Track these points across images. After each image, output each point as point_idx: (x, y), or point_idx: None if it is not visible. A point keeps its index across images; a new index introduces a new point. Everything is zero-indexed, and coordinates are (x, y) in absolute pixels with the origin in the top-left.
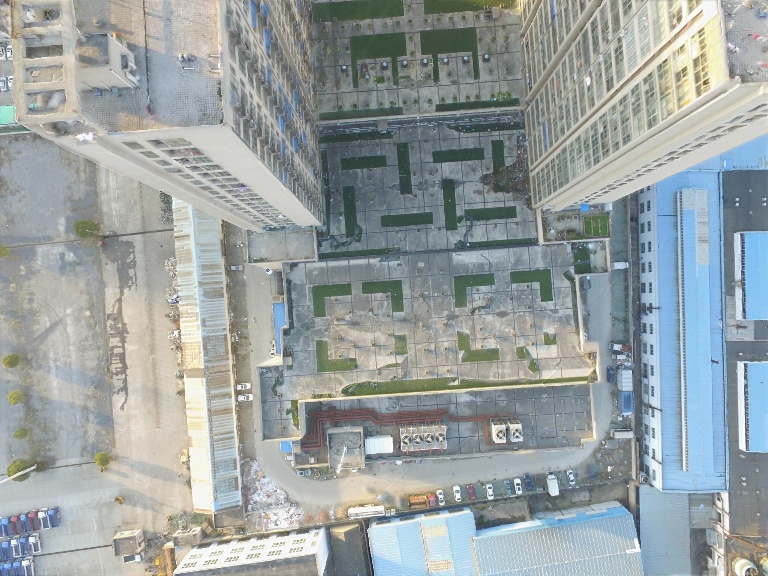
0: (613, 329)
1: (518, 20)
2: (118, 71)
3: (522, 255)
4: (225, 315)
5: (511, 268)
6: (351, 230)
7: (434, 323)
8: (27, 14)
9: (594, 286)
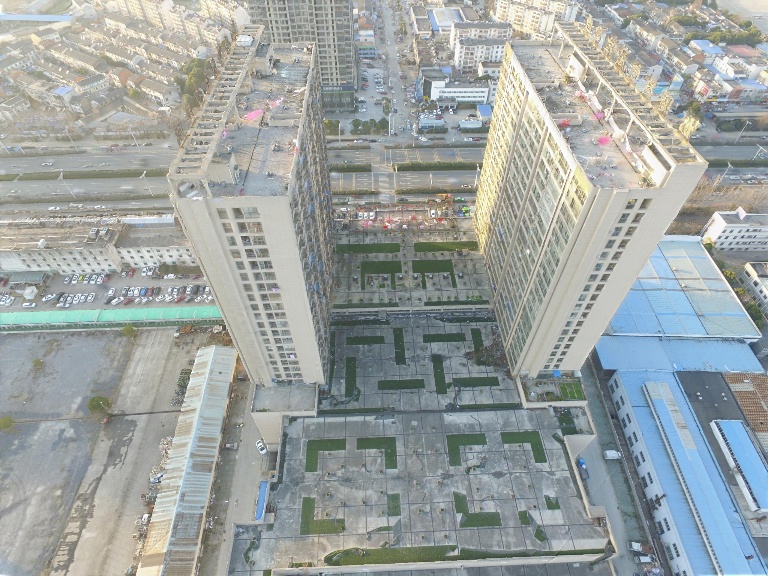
0: (626, 526)
1: (481, 257)
2: (231, 169)
3: (509, 417)
4: (207, 492)
5: (501, 429)
6: (350, 391)
7: (429, 482)
8: (127, 255)
9: (592, 476)
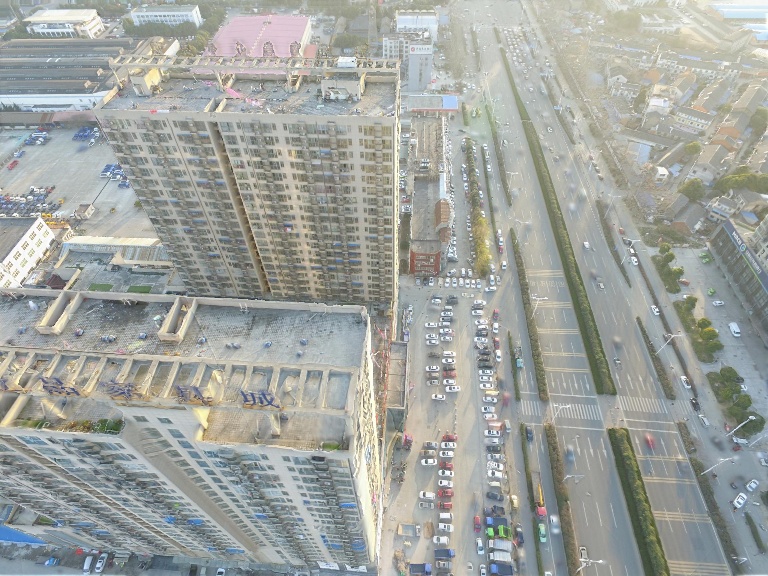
0: None
1: None
2: None
3: None
4: None
5: None
6: None
7: None
8: None
9: (35, 571)
